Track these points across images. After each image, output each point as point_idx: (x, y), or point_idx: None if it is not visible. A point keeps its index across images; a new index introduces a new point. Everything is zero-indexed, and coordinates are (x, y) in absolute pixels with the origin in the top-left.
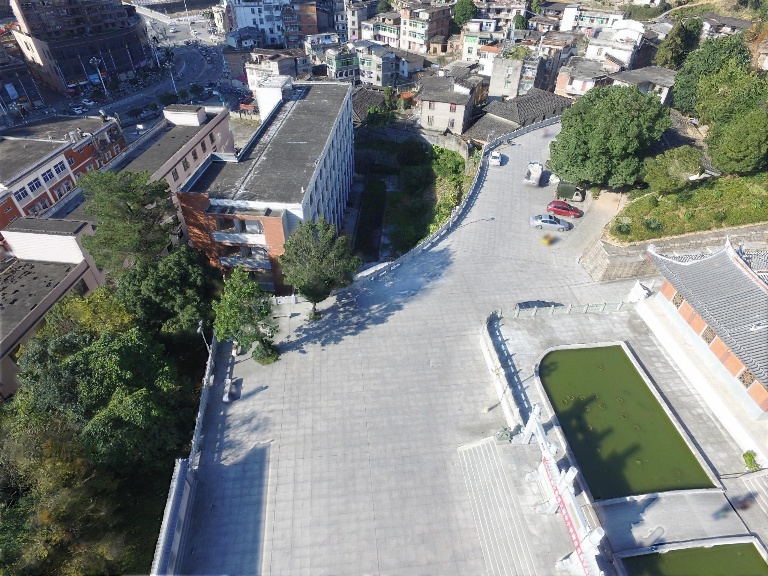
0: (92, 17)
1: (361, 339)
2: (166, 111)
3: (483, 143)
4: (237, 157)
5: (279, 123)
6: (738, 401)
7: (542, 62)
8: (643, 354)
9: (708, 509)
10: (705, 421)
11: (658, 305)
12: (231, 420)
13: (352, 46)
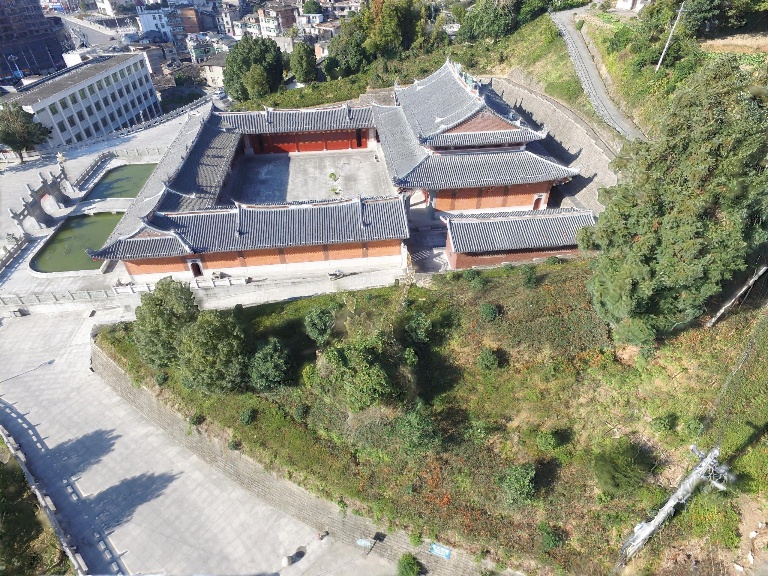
0: (18, 25)
1: (39, 169)
2: (23, 79)
3: None
4: (16, 89)
5: (67, 74)
6: None
7: (313, 39)
8: None
9: (127, 203)
10: None
11: None
12: None
13: (208, 38)
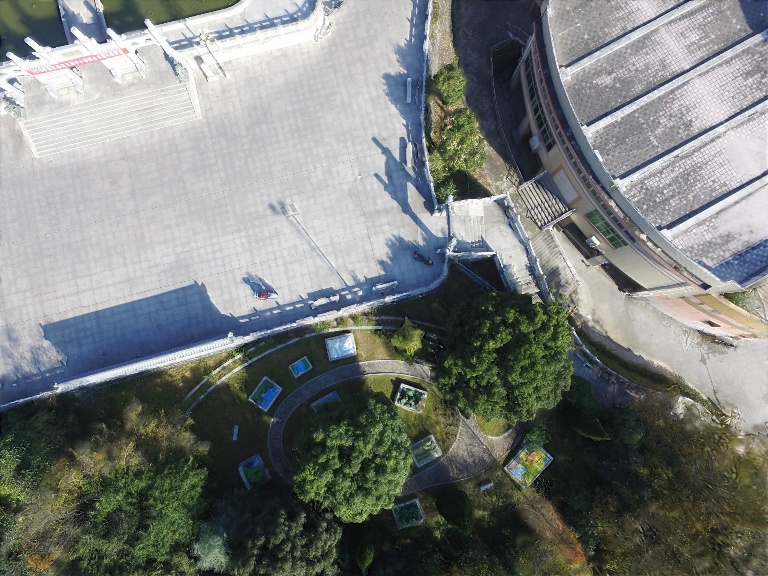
0: None
1: None
2: None
3: None
4: None
5: None
6: None
7: None
8: None
9: None
10: None
11: None
12: (22, 372)
13: None
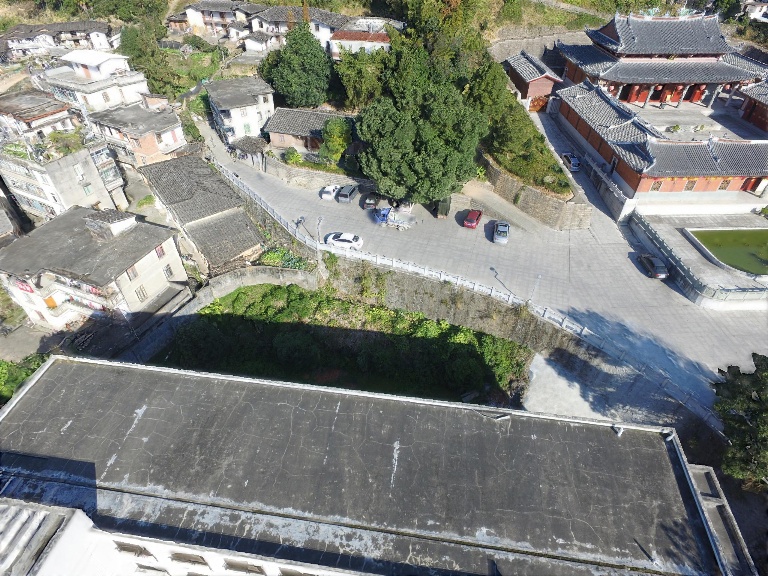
0: None
1: None
2: None
3: (246, 253)
4: None
5: (264, 519)
6: (723, 199)
7: None
8: (686, 225)
9: None
10: (734, 219)
11: (641, 201)
12: None
13: None
